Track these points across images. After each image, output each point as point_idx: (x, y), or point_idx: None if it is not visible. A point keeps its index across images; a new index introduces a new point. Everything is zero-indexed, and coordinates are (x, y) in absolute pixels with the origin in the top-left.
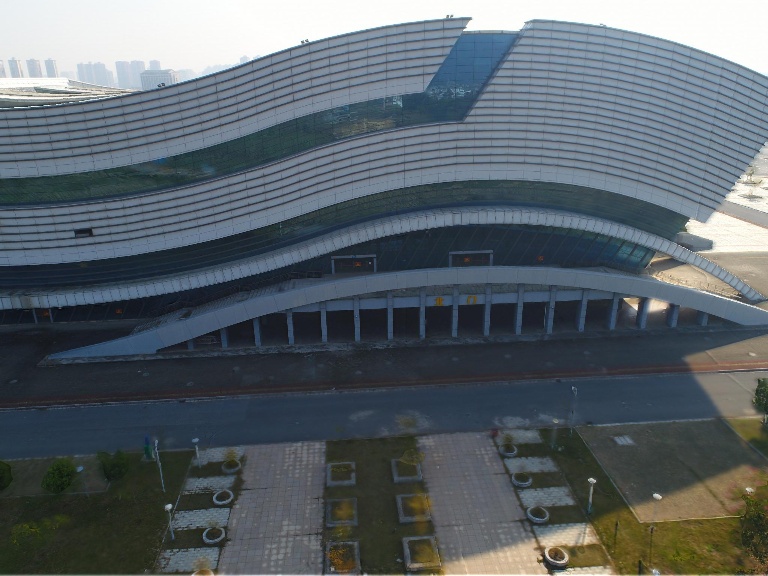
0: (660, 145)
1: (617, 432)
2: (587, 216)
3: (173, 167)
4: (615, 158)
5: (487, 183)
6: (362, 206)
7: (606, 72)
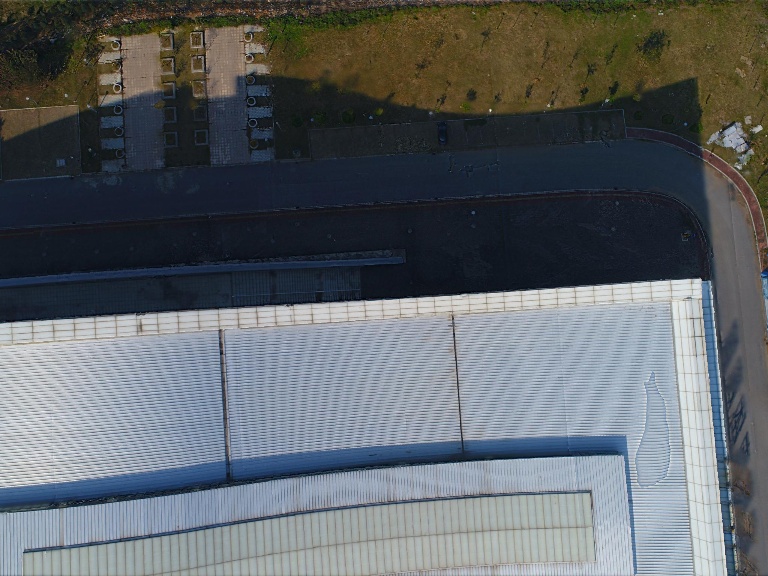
0: None
1: (61, 169)
2: None
3: None
4: None
5: None
6: None
7: None
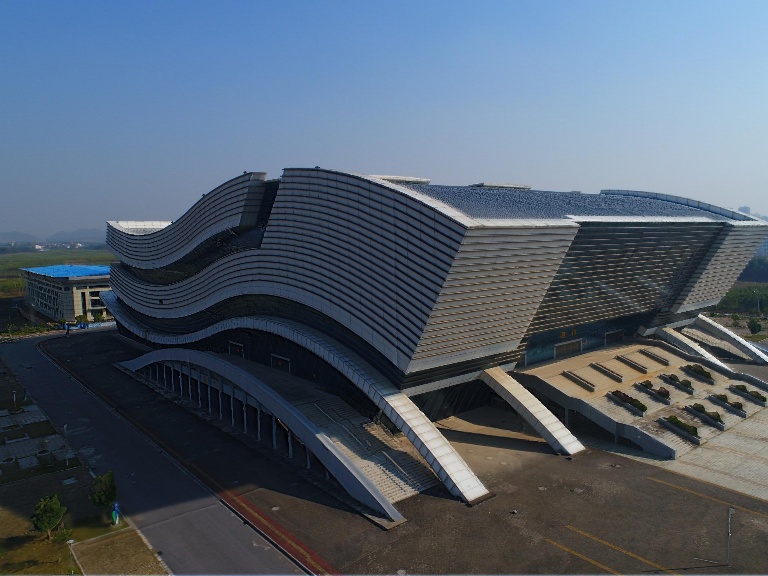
0: (360, 277)
1: None
2: (328, 341)
3: (181, 269)
4: (334, 287)
5: (274, 298)
6: (236, 306)
7: (321, 208)
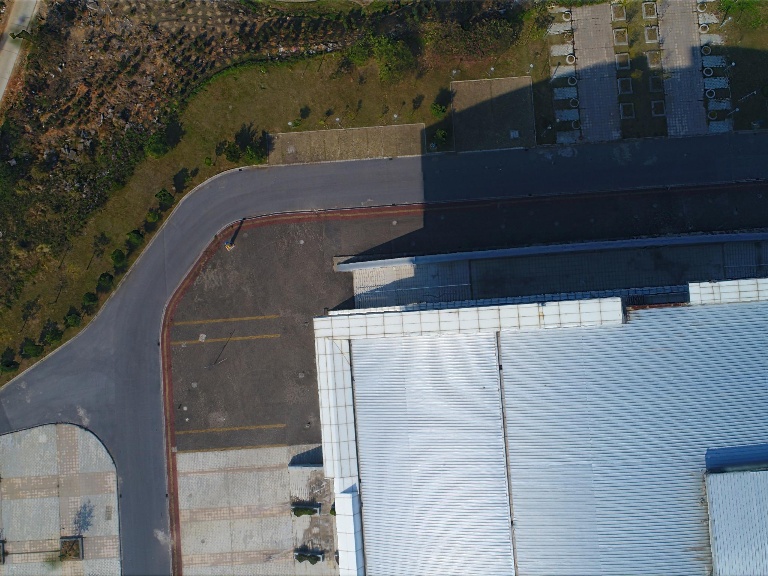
0: None
1: (515, 141)
2: None
3: None
4: None
5: None
6: None
7: None
